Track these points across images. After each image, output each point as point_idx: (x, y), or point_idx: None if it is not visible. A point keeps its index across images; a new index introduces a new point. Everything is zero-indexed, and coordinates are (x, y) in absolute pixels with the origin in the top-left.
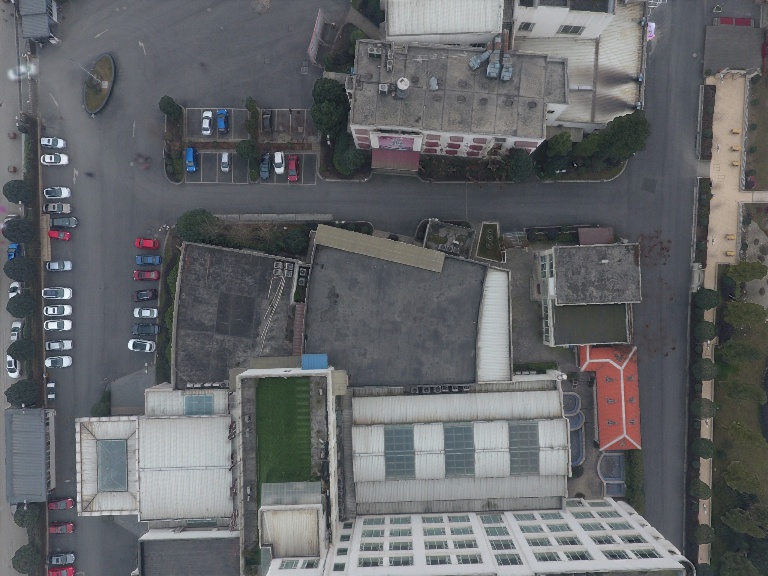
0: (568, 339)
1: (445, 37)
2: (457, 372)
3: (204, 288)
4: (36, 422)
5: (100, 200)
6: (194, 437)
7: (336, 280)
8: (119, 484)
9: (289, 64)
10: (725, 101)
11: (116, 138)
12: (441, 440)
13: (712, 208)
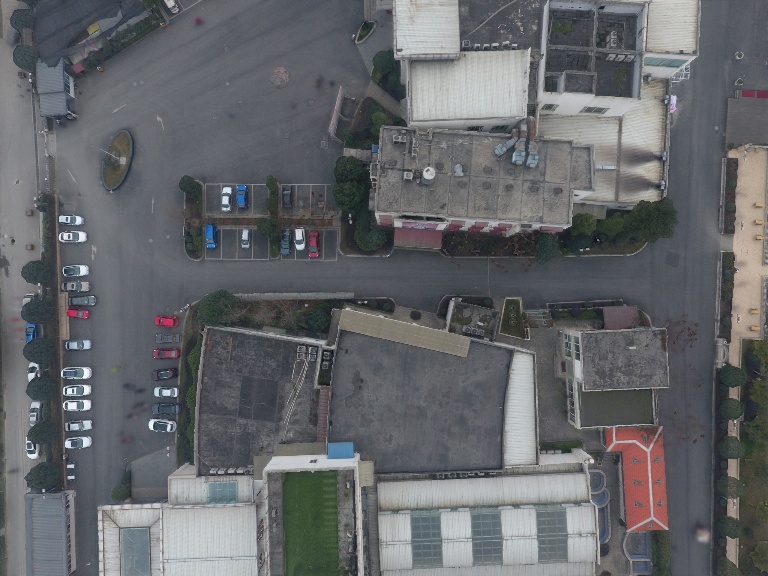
0: (594, 421)
1: (469, 122)
2: (483, 457)
3: (226, 372)
4: (56, 506)
5: (119, 277)
6: (219, 527)
7: (360, 365)
8: (142, 573)
9: (309, 139)
10: (748, 174)
11: (135, 214)
12: (468, 527)
13: (736, 282)
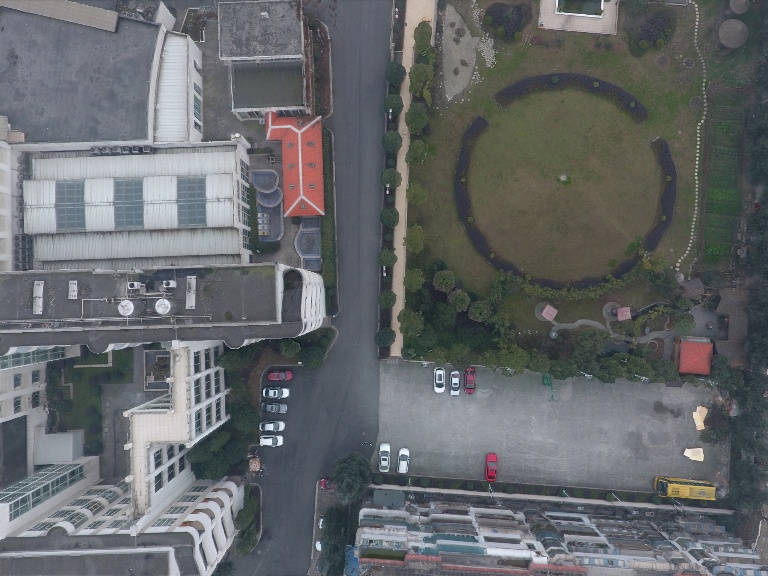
0: (247, 103)
1: None
2: (132, 130)
3: None
4: None
5: None
6: None
7: (16, 42)
8: None
9: None
10: None
11: None
12: (111, 193)
13: None
